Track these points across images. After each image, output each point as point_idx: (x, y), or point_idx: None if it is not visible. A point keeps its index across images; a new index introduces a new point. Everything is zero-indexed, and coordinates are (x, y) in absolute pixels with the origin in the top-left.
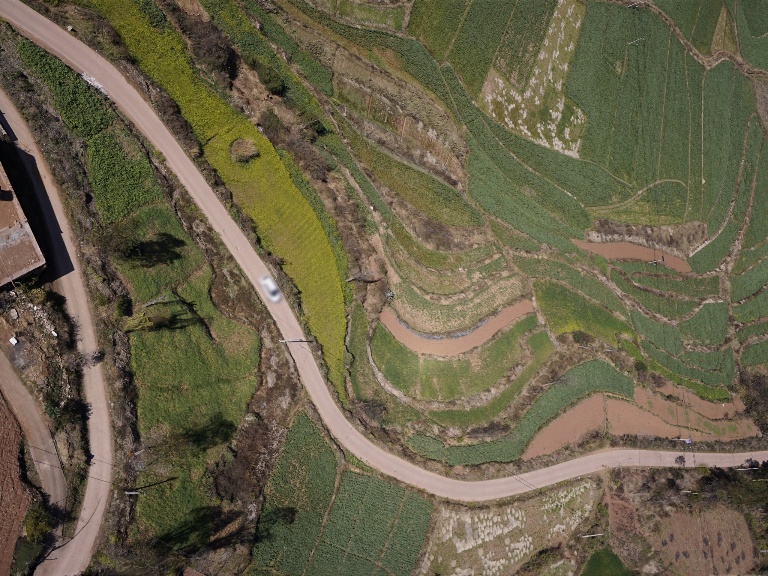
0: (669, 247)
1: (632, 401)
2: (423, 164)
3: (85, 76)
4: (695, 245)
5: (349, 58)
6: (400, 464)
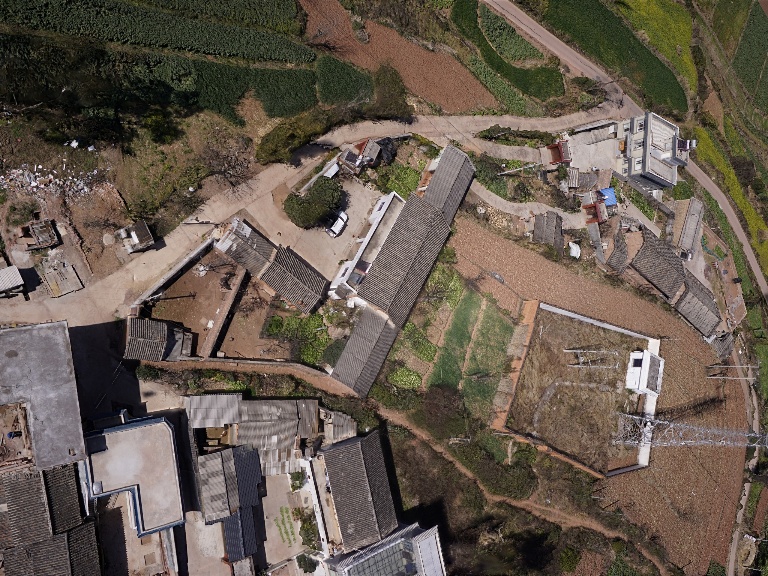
0: None
1: None
2: None
3: None
4: None
5: None
6: None
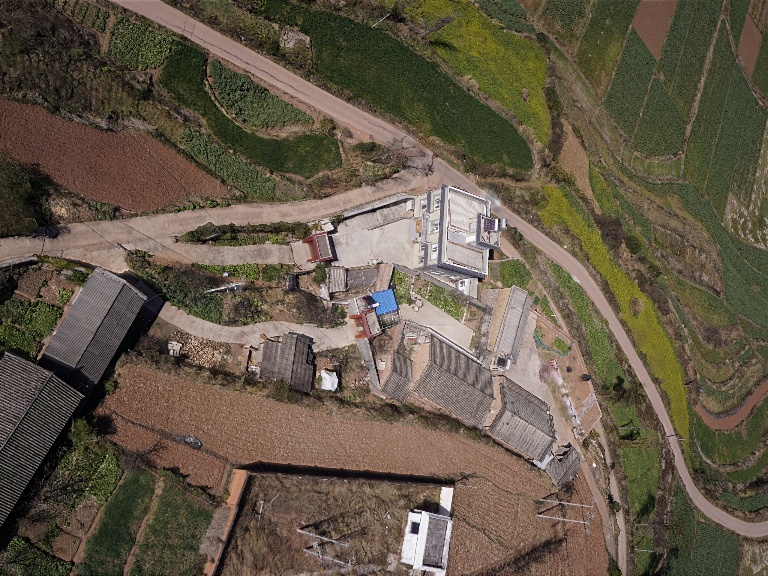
0: None
1: None
2: (701, 282)
3: (572, 277)
4: None
5: (657, 209)
6: (721, 514)
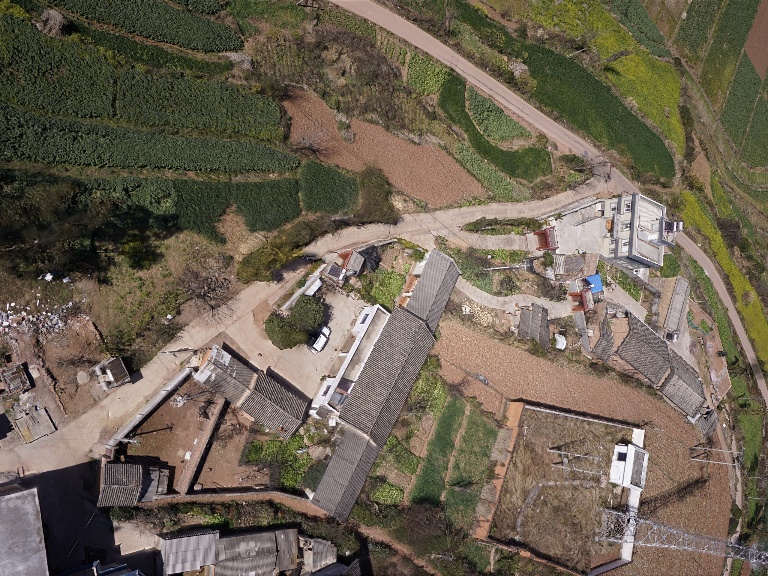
0: None
1: None
2: None
3: None
4: None
5: (758, 214)
6: None
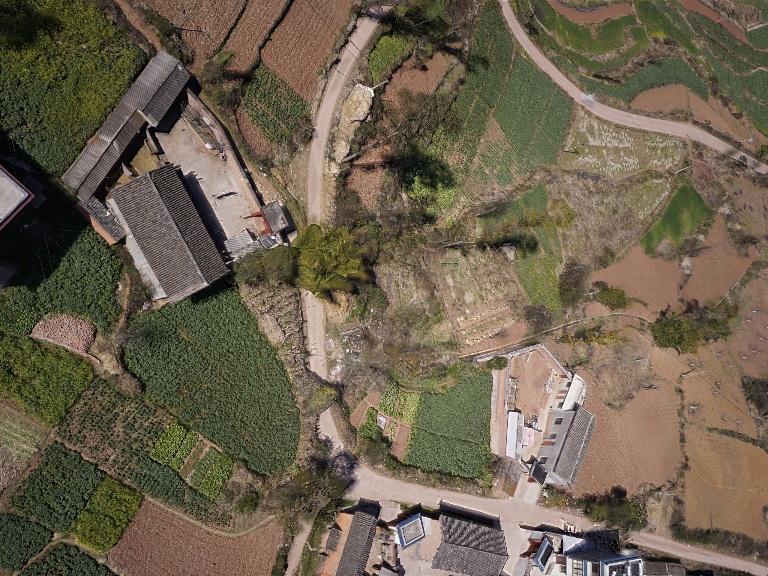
0: (731, 17)
1: (707, 102)
2: None
3: None
4: (751, 24)
5: None
6: (551, 67)
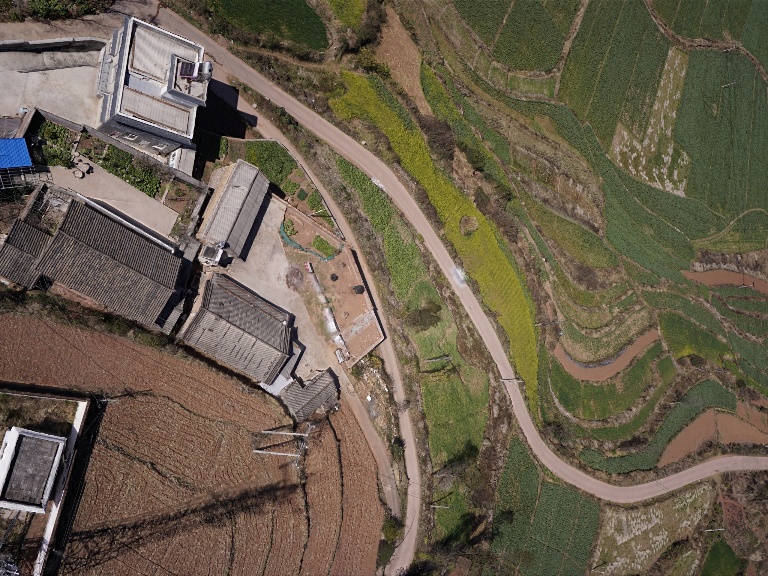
0: (755, 271)
1: (735, 414)
2: (574, 216)
3: (373, 179)
4: None
5: (519, 128)
6: (577, 474)
